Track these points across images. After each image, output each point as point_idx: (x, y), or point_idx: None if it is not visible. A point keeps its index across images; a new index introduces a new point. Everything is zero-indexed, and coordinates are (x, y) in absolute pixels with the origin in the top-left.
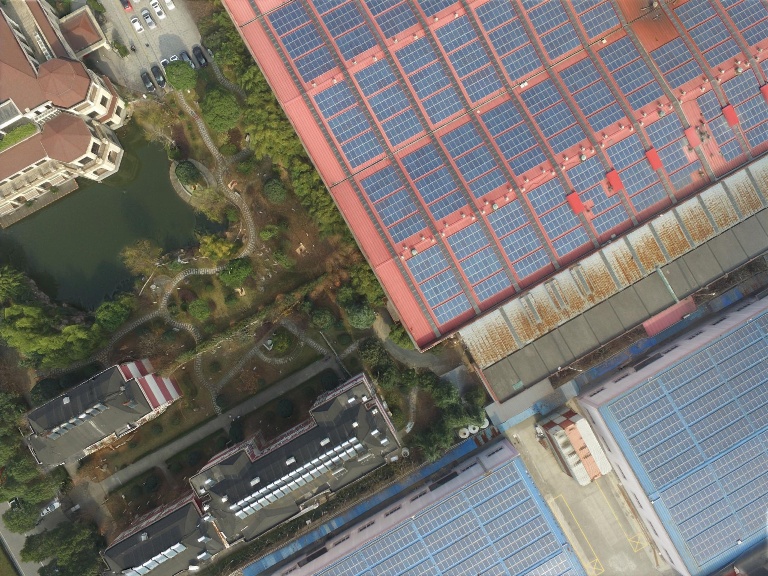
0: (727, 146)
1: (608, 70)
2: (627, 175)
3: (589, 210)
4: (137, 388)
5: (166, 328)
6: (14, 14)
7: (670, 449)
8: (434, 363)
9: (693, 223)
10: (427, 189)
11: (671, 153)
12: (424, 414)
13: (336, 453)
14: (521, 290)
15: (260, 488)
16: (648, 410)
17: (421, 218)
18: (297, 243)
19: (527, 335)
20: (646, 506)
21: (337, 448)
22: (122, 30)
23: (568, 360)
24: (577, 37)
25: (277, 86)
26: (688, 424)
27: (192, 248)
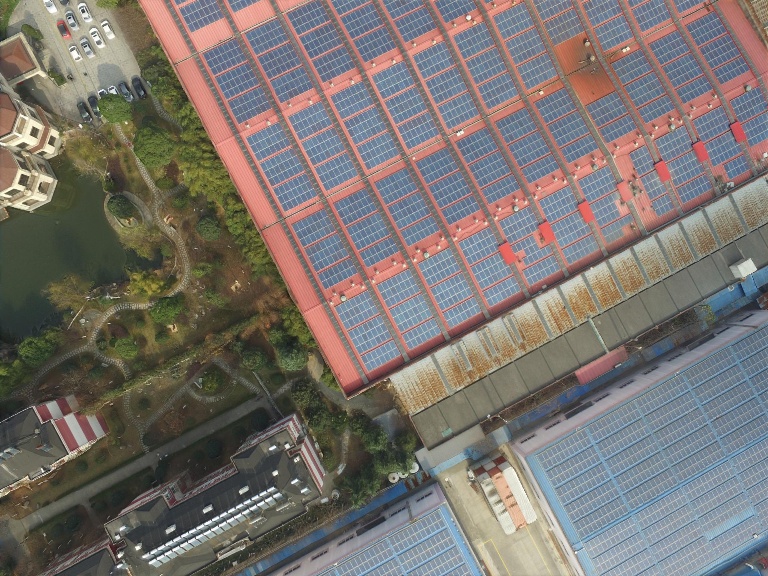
0: (659, 201)
1: (544, 122)
2: (559, 227)
3: (521, 261)
4: (53, 431)
5: (95, 363)
6: None
7: (595, 499)
8: (368, 405)
9: (625, 274)
10: (359, 235)
11: (603, 206)
12: (356, 456)
13: (254, 502)
14: (451, 338)
15: (175, 537)
16: (575, 460)
17: (352, 264)
18: (232, 280)
19: (458, 382)
20: (571, 555)
21: (255, 498)
22: (60, 58)
23: (498, 408)
24: (515, 87)
25: (210, 126)
26: (614, 475)
27: (125, 282)
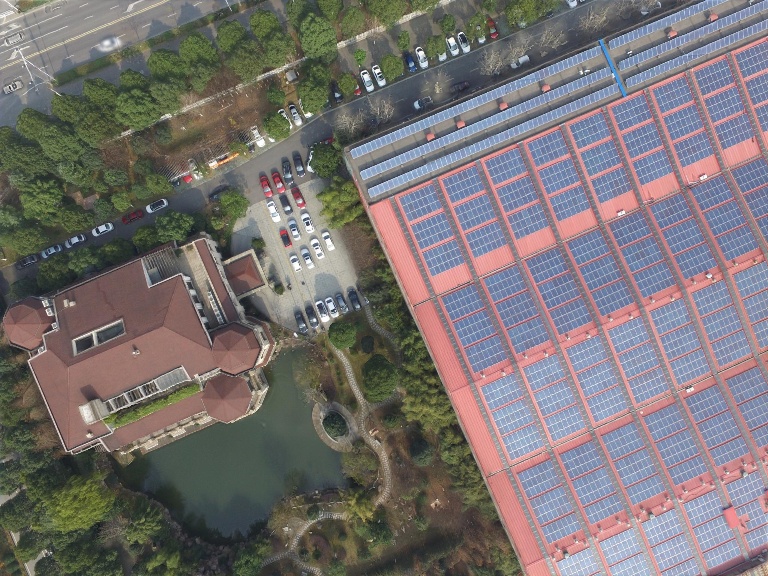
0: None
1: None
2: None
3: (744, 525)
4: None
5: (294, 571)
6: (187, 266)
7: None
8: None
9: None
10: (584, 490)
11: None
12: None
13: None
14: None
15: None
16: None
17: (576, 520)
18: (433, 498)
19: None
20: None
21: None
22: (280, 266)
23: None
24: (748, 346)
25: (445, 373)
26: None
27: (327, 491)
